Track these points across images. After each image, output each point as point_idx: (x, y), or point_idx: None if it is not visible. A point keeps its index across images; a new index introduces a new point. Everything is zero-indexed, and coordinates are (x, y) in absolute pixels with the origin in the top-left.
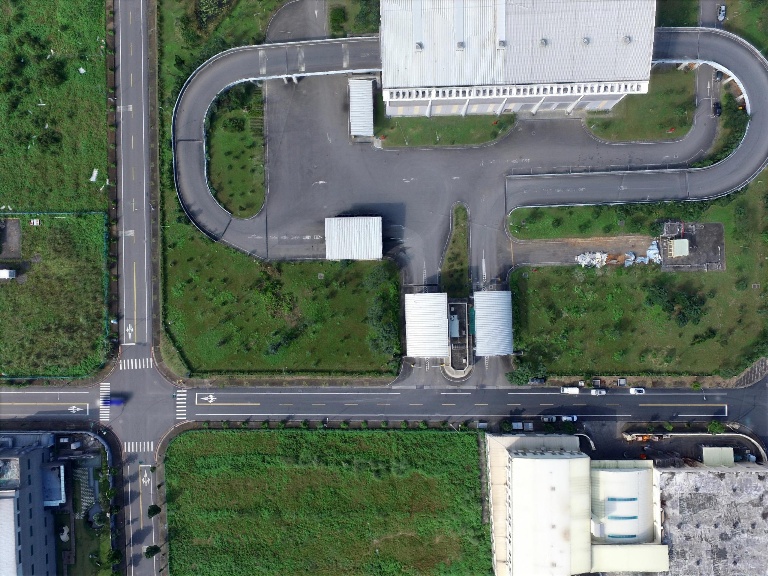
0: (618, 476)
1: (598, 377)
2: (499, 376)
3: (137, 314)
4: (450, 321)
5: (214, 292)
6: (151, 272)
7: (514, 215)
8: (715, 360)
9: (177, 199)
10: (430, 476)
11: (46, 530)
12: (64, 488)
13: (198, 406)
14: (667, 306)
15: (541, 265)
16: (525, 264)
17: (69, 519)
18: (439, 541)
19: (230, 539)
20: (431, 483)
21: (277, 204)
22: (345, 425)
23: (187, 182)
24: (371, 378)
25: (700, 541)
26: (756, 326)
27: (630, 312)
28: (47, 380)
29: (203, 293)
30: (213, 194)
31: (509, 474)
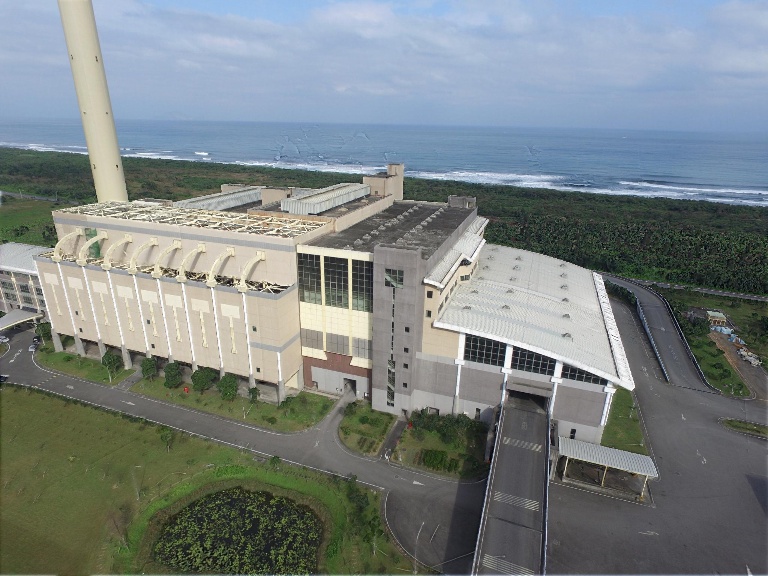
0: None
1: None
2: None
3: None
4: None
5: None
6: None
7: None
8: None
9: None
10: None
11: None
12: None
13: None
14: None
15: None
16: None
17: None
18: None
19: None
20: None
21: None
22: None
23: None
24: None
25: None
26: None
27: None
28: None
29: None
30: None
31: None
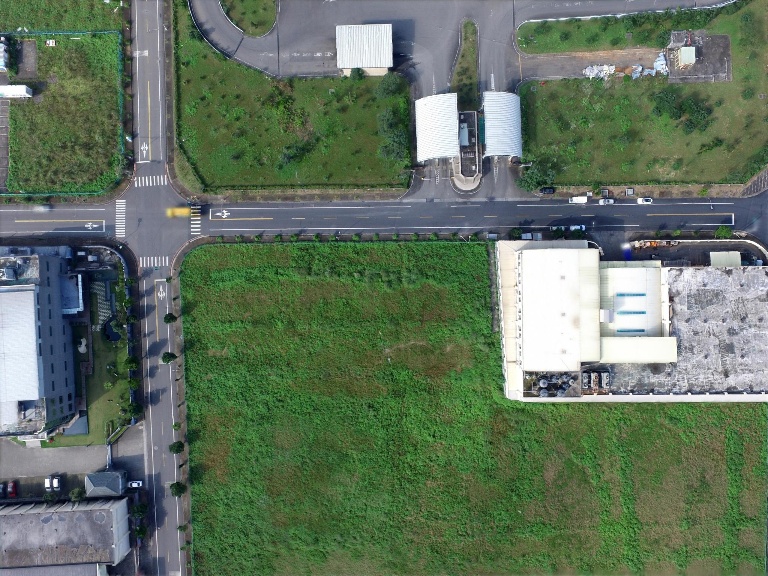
0: (626, 272)
1: (606, 188)
2: (508, 188)
3: (151, 132)
4: (460, 130)
5: (227, 109)
6: (165, 91)
7: (522, 30)
8: (722, 169)
9: (190, 16)
10: (441, 286)
11: (64, 338)
12: (82, 296)
13: (212, 221)
14: (674, 112)
15: (549, 79)
16: (533, 78)
17: (87, 331)
18: (450, 349)
19: (244, 350)
20: (442, 293)
21: (288, 22)
22: (357, 237)
23: (200, 1)
24: (382, 192)
25: (708, 336)
26: (762, 135)
27: (637, 123)
28: (64, 197)
29: (216, 110)
30: (225, 11)
31: (519, 270)
